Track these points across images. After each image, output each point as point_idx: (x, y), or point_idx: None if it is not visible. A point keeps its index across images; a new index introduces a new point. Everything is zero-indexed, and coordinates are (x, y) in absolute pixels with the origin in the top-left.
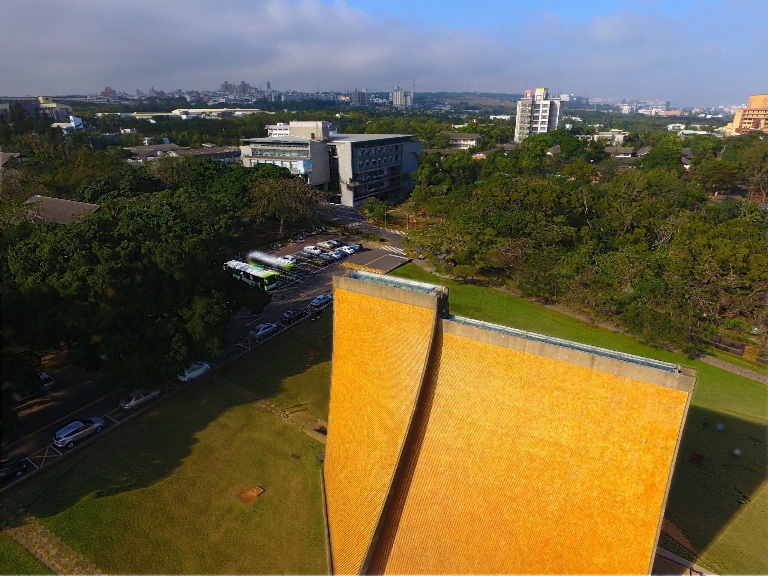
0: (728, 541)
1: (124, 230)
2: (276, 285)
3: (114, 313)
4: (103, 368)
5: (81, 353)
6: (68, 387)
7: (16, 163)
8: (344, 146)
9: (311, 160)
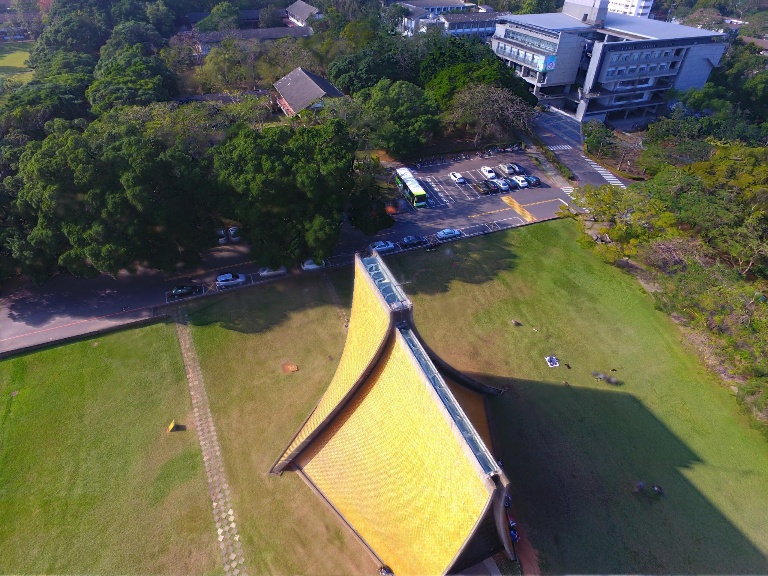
0: None
1: (292, 145)
2: (427, 203)
3: (262, 212)
4: (252, 245)
5: (238, 233)
6: (245, 244)
7: (313, 20)
8: (598, 46)
9: (556, 56)
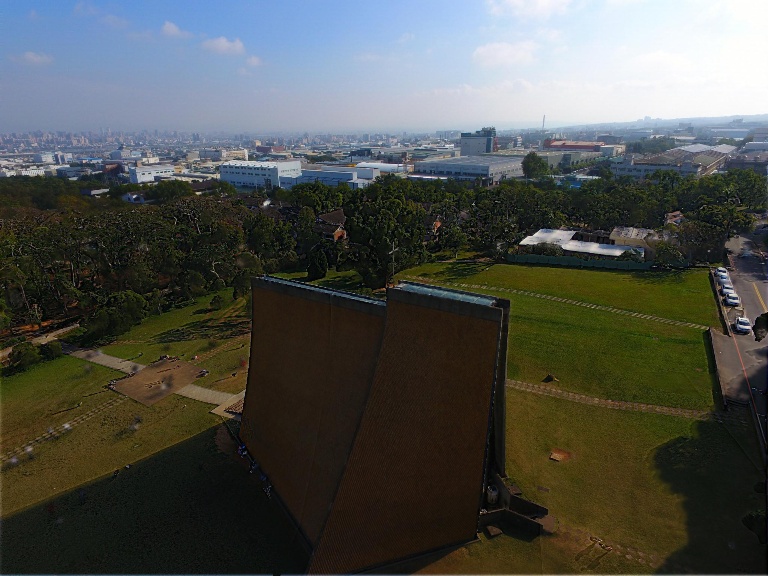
0: (186, 436)
1: None
2: None
3: None
4: None
5: None
6: None
7: None
8: None
9: None
